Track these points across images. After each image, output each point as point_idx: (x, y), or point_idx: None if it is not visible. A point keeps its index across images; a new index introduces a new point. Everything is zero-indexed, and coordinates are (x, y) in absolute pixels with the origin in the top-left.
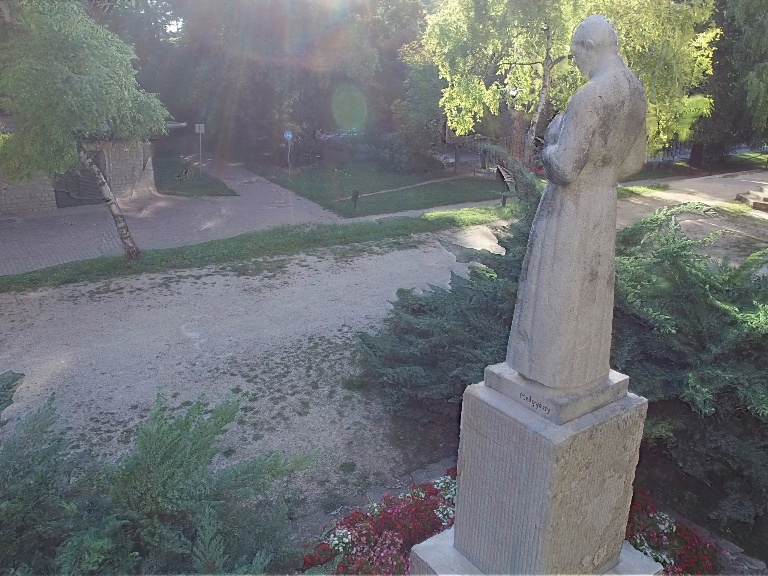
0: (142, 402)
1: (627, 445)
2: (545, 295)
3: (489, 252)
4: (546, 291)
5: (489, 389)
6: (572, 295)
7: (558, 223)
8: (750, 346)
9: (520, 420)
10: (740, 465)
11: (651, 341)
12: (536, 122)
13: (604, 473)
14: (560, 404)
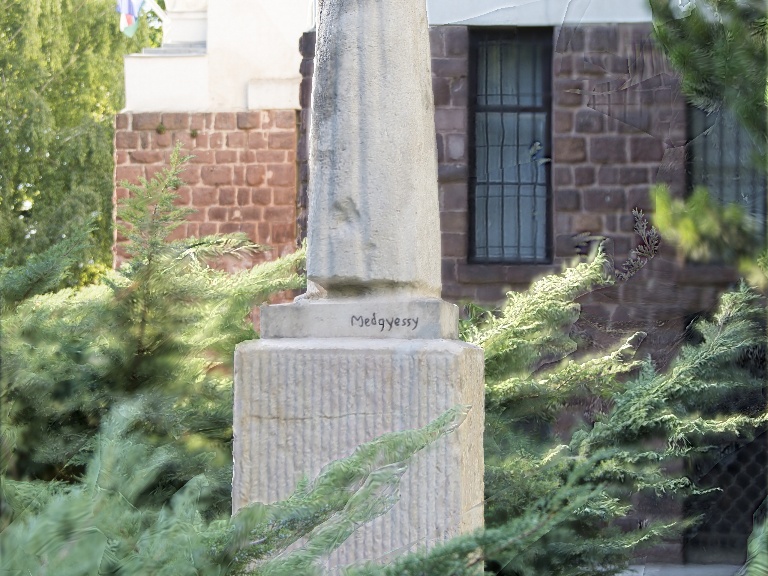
0: None
1: None
2: (379, 126)
3: None
4: (380, 120)
5: None
6: (417, 122)
7: (381, 10)
8: None
9: (377, 347)
10: None
11: None
12: None
13: None
14: (435, 301)
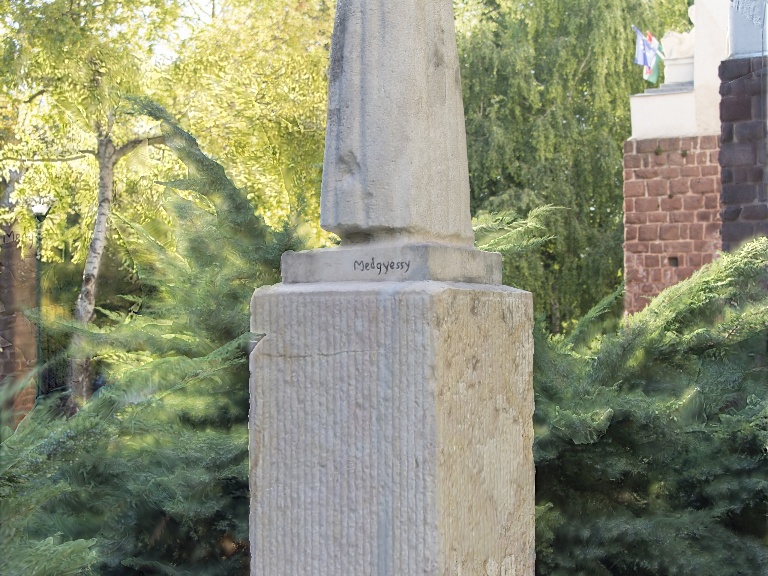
0: None
1: (517, 361)
2: (377, 83)
3: (135, 329)
4: (378, 77)
5: (294, 283)
6: (416, 78)
7: None
8: (630, 374)
9: (365, 288)
10: (661, 561)
11: None
12: (93, 275)
13: (495, 396)
14: (424, 245)
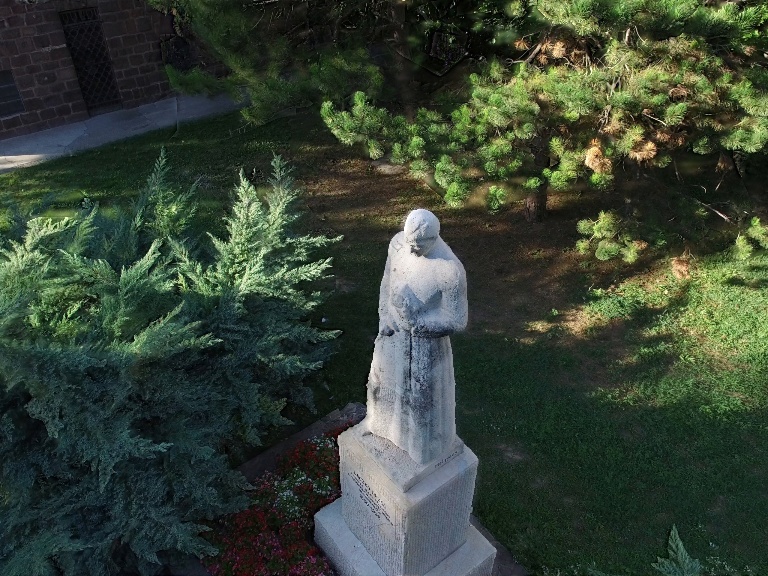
0: None
1: None
2: None
3: None
4: None
5: (413, 490)
6: None
7: None
8: None
9: (454, 476)
10: None
11: (160, 360)
12: None
13: None
14: None
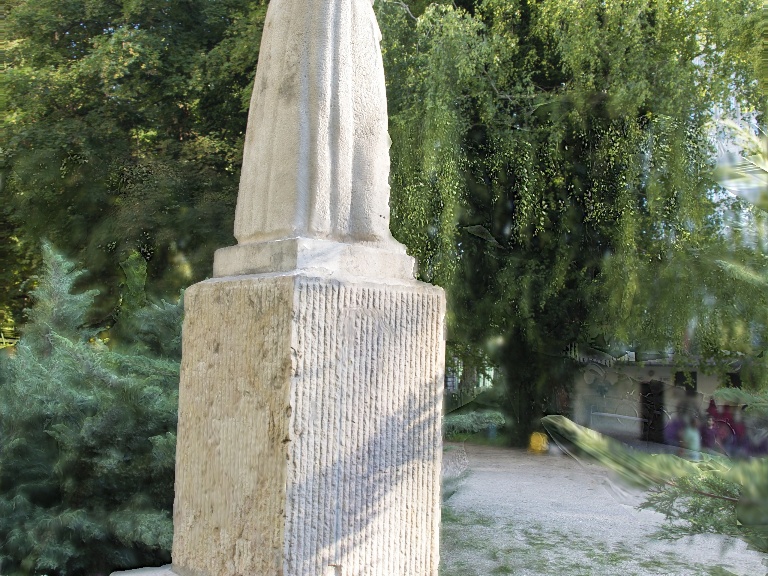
0: (682, 555)
1: None
2: None
3: None
4: None
5: None
6: None
7: None
8: None
9: None
10: None
11: None
12: None
13: None
14: None
